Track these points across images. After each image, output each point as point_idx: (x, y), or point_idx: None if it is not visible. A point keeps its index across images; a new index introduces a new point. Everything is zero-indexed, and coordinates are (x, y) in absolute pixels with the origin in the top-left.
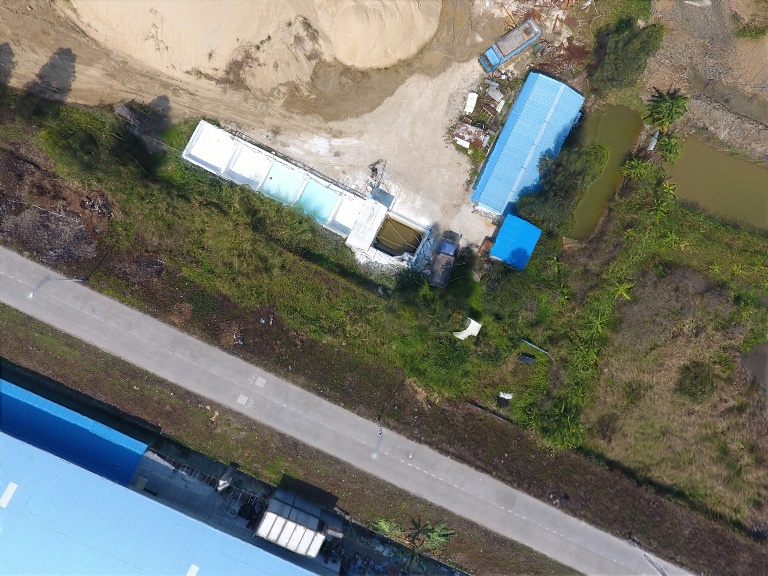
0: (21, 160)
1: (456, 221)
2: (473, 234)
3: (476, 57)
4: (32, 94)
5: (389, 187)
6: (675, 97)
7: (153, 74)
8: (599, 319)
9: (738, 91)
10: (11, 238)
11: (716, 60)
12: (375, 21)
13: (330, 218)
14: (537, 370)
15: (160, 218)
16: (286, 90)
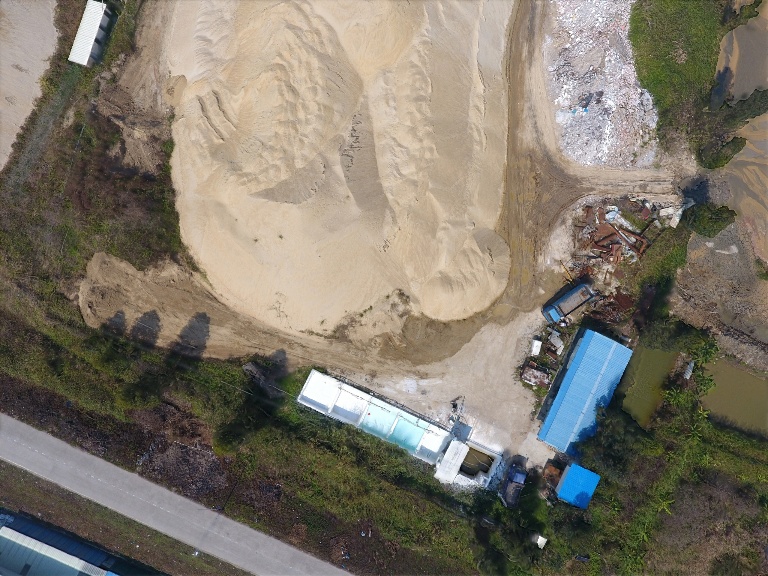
0: (164, 403)
1: (523, 446)
2: (538, 457)
3: (539, 307)
4: (175, 352)
5: (467, 419)
6: (709, 343)
7: (272, 331)
8: (645, 530)
9: (761, 323)
10: (161, 476)
11: (742, 298)
12: (458, 292)
13: (419, 447)
14: (591, 567)
15: (280, 454)
16: (381, 340)
